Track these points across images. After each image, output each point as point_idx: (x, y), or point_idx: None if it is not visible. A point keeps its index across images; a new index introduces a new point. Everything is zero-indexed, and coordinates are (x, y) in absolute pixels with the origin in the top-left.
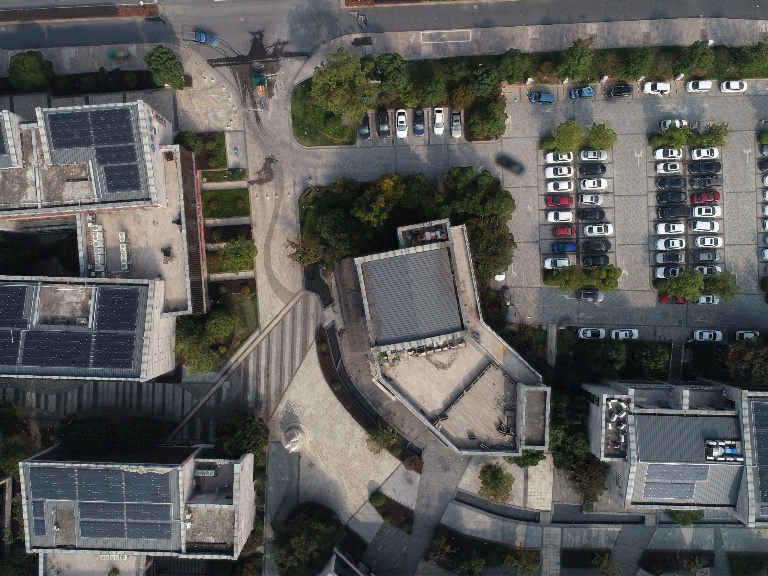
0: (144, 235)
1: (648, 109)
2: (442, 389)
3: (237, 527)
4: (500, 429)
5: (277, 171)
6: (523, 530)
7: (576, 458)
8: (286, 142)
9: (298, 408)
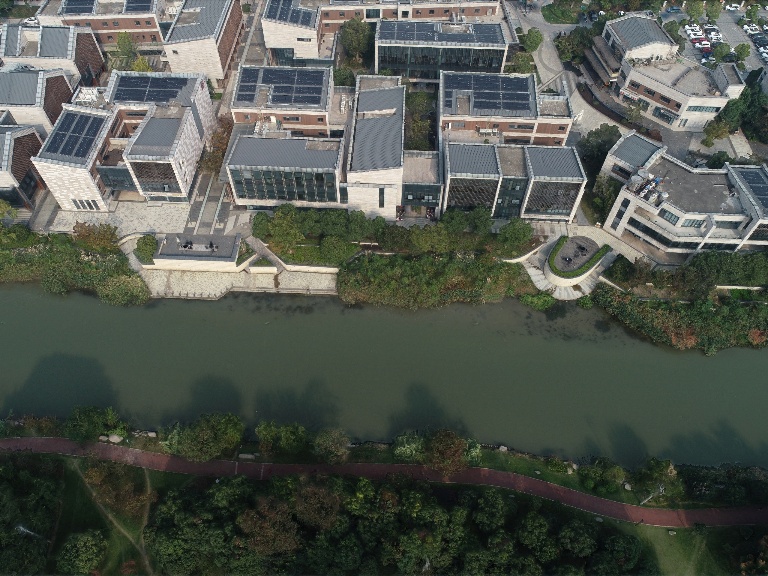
0: None
1: (731, 15)
2: (669, 78)
3: None
4: (711, 89)
5: None
6: None
7: (763, 109)
8: (542, 23)
9: None
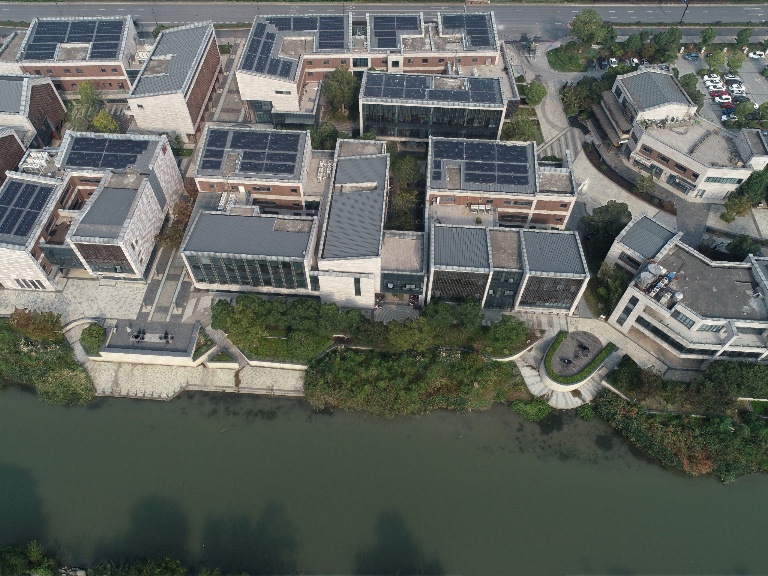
0: (484, 75)
1: (755, 64)
2: (685, 143)
3: (574, 179)
4: (733, 159)
5: (543, 80)
6: (766, 251)
7: None
8: (547, 70)
9: (578, 180)
